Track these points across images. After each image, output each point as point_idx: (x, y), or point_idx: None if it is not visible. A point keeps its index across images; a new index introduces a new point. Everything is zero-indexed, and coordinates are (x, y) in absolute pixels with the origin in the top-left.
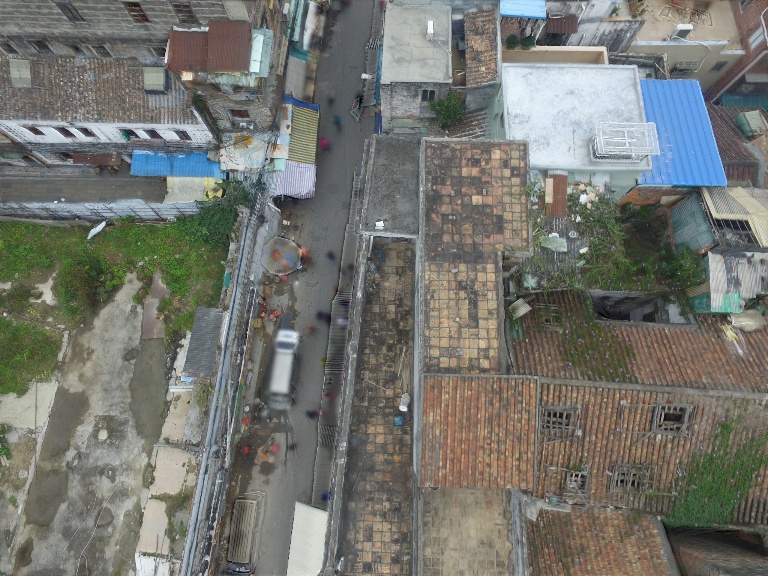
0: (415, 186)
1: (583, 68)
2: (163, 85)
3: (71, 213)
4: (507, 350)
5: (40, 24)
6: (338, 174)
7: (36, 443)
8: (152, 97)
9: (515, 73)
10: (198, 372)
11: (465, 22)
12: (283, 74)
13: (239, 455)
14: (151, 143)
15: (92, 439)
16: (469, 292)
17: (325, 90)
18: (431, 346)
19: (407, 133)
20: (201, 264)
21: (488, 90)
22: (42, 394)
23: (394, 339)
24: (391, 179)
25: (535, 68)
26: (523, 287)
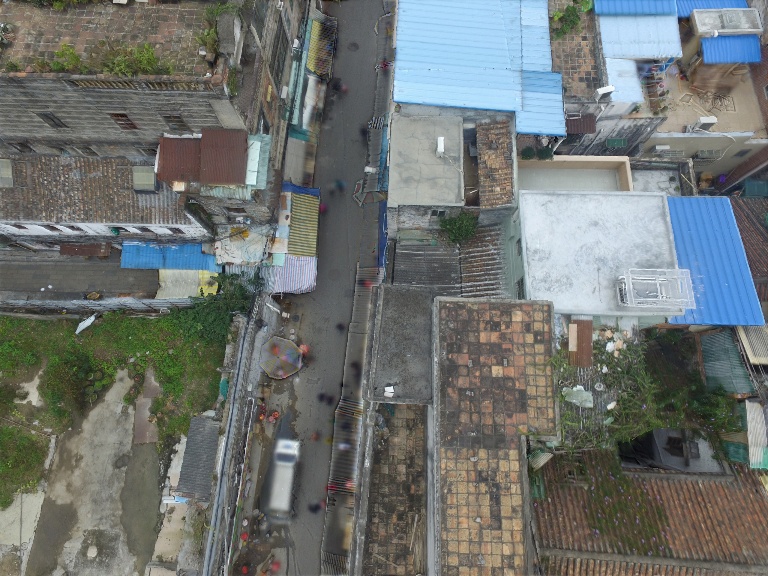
0: (427, 343)
1: (607, 195)
2: (154, 185)
3: (58, 306)
4: (531, 536)
5: (20, 130)
6: (340, 258)
7: (21, 562)
8: (142, 196)
9: (533, 201)
10: (193, 492)
11: (477, 133)
12: (281, 162)
13: (237, 574)
14: (142, 236)
15: (81, 557)
16: (490, 484)
17: (326, 166)
18: (449, 552)
19: (415, 245)
20: (196, 361)
21: (503, 211)
22: (27, 506)
23: (405, 505)
24: (401, 334)
25: (555, 195)
26: (545, 446)
